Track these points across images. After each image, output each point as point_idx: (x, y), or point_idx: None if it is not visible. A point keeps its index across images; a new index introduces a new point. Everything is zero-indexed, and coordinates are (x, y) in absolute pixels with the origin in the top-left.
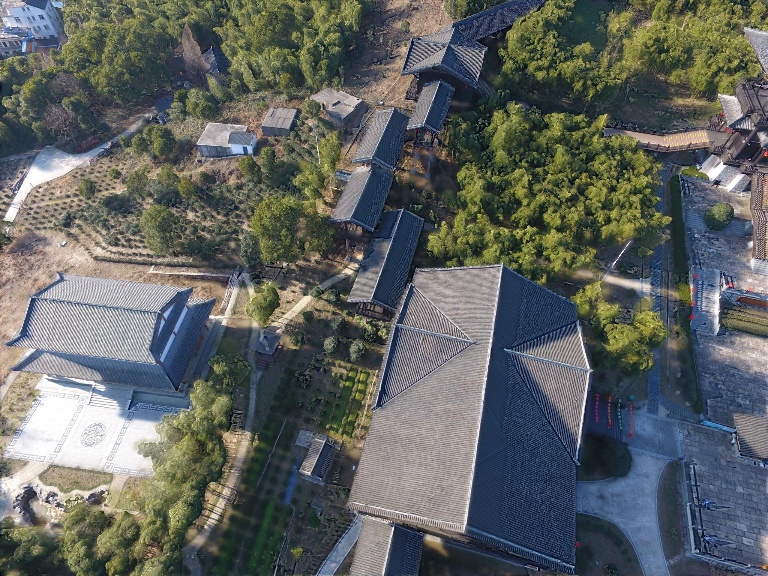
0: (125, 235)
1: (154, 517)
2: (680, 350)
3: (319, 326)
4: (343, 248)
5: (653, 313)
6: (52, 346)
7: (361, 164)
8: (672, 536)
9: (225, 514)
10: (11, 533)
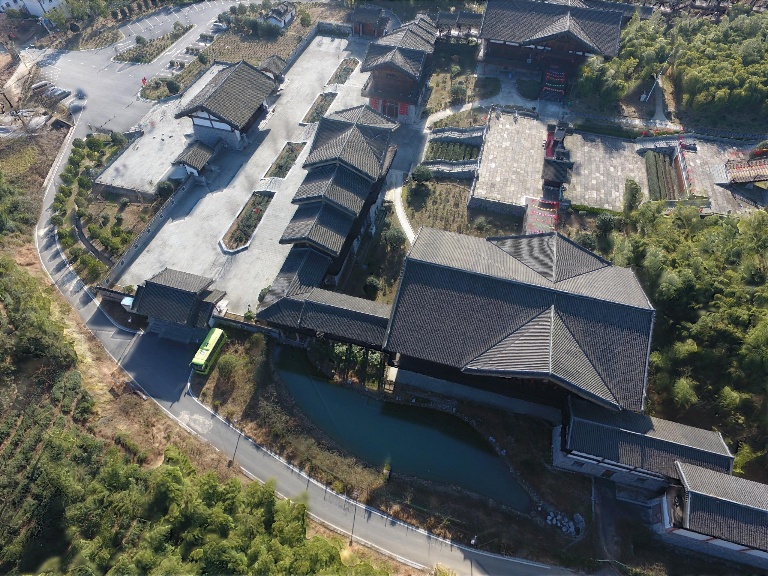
0: None
1: None
2: None
3: None
4: None
5: None
6: None
7: (693, 12)
8: None
9: None
10: None
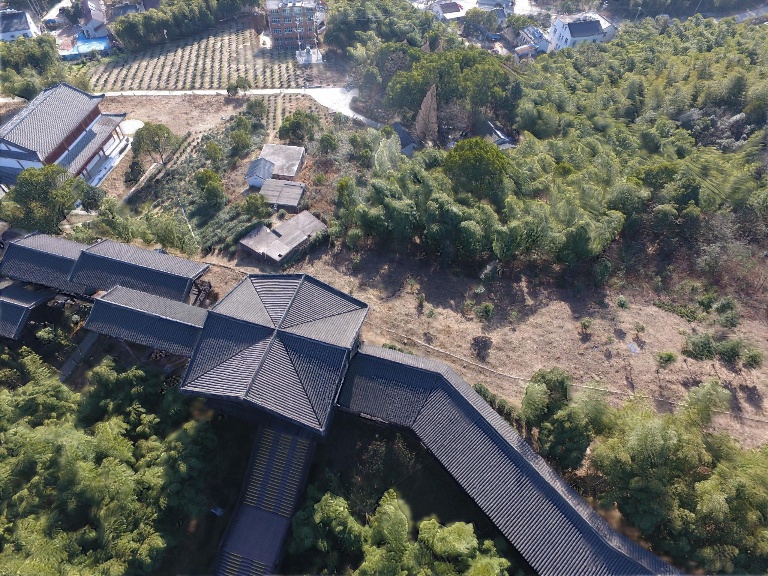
0: None
1: None
2: None
3: None
4: None
5: None
6: None
7: None
8: None
9: None
10: None
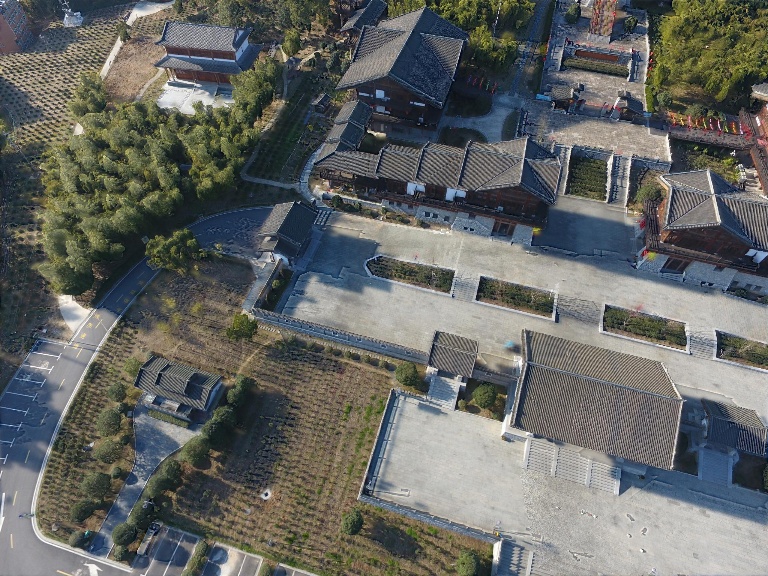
0: None
1: (239, 104)
2: None
3: (324, 62)
4: (339, 30)
5: (513, 41)
6: (179, 45)
7: None
8: (507, 132)
9: (272, 128)
10: None
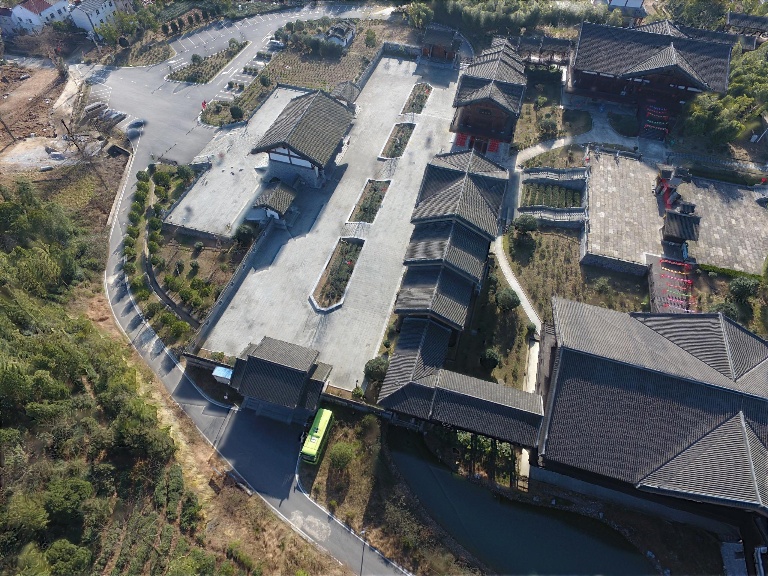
0: (673, 8)
1: (551, 7)
2: None
3: None
4: None
5: None
6: None
7: None
8: None
9: None
10: None
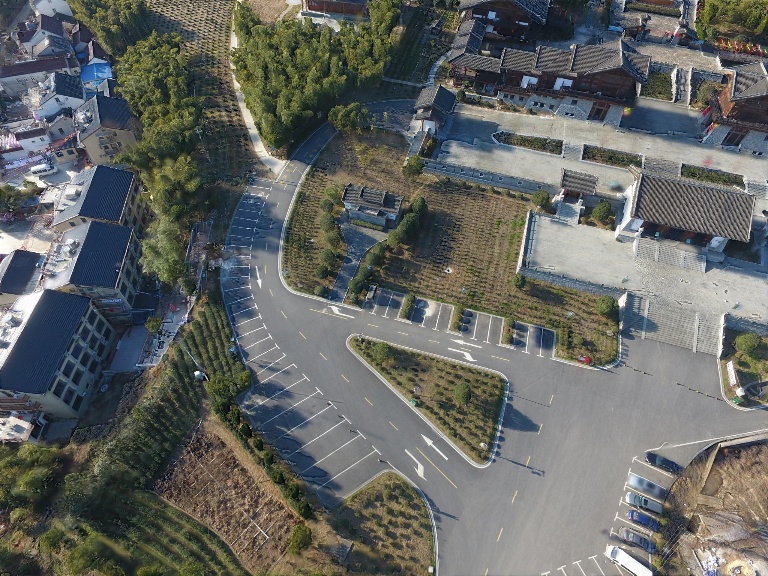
0: None
1: (377, 22)
2: (603, 11)
3: (428, 1)
4: None
5: None
6: None
7: None
8: None
9: None
10: (321, 24)
